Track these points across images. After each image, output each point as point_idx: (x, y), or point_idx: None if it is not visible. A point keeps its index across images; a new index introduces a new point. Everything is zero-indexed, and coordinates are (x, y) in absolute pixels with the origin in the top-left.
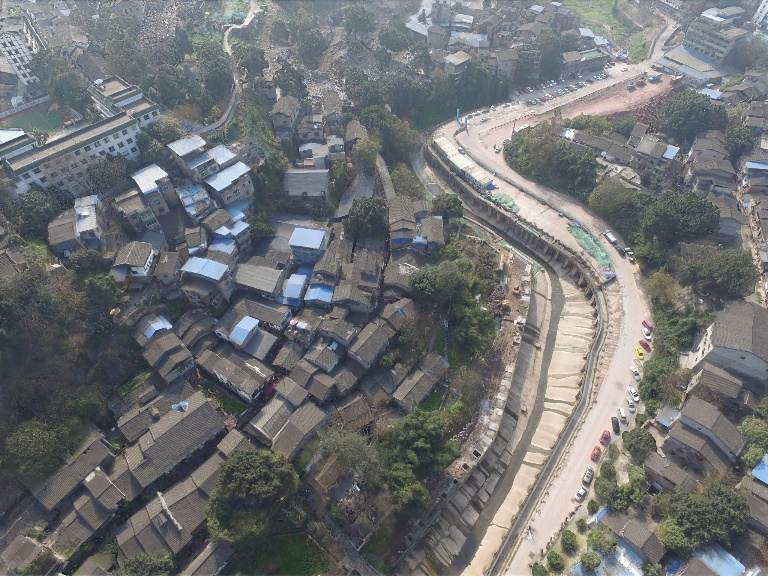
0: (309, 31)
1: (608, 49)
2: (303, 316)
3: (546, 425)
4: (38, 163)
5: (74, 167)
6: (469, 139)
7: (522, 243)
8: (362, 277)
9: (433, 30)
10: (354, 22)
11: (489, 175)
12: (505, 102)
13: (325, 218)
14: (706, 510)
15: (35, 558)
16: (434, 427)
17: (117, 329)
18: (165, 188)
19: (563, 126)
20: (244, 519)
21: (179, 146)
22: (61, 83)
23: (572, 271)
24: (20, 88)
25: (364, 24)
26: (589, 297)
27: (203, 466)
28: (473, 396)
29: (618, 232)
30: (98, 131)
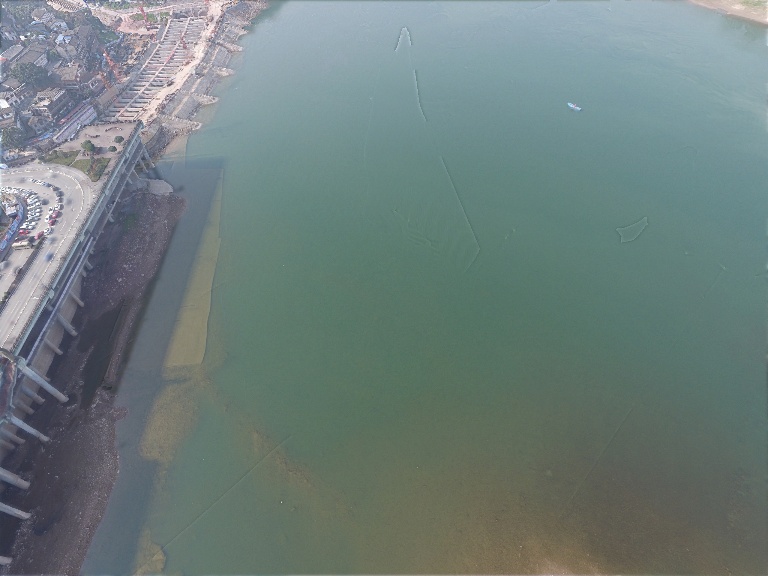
0: None
1: None
2: None
3: (55, 7)
4: None
5: None
6: None
7: None
8: None
9: None
10: None
11: None
12: None
13: None
14: None
15: None
16: None
17: None
18: None
19: None
20: (21, 1)
21: None
22: None
23: None
24: None
25: None
26: None
27: None
28: None
29: None
30: None
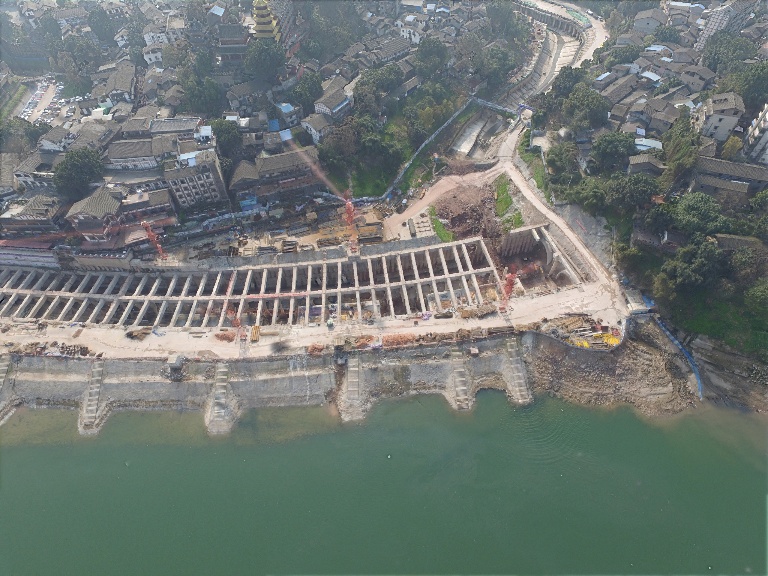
0: None
1: None
2: None
3: None
4: None
5: None
6: None
7: None
8: (463, 5)
9: None
10: None
11: None
12: None
13: None
14: (622, 49)
15: (355, 59)
16: (505, 50)
17: (355, 12)
18: None
19: None
20: None
21: None
22: None
23: (569, 30)
24: None
25: None
26: (578, 39)
27: (404, 58)
28: (519, 58)
29: (594, 11)
30: None
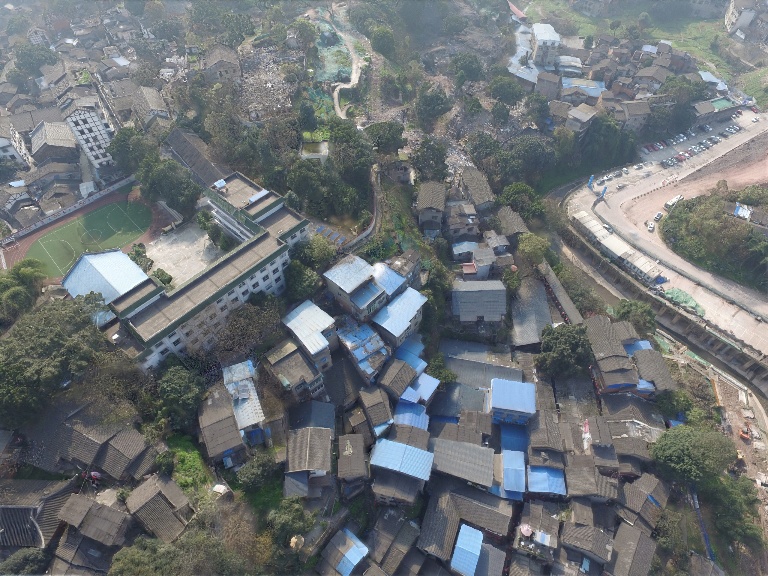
0: (416, 84)
1: (729, 94)
2: (533, 517)
3: None
4: (175, 326)
5: (212, 317)
6: (611, 213)
7: (710, 352)
8: (595, 451)
9: (545, 77)
10: (465, 72)
11: (652, 262)
12: (635, 162)
13: (502, 346)
14: None
15: None
16: None
17: (303, 570)
18: (327, 335)
19: (727, 199)
20: None
21: (342, 277)
22: (159, 178)
23: None
24: (84, 167)
25: (476, 74)
26: None
27: None
28: None
29: None
30: (240, 264)
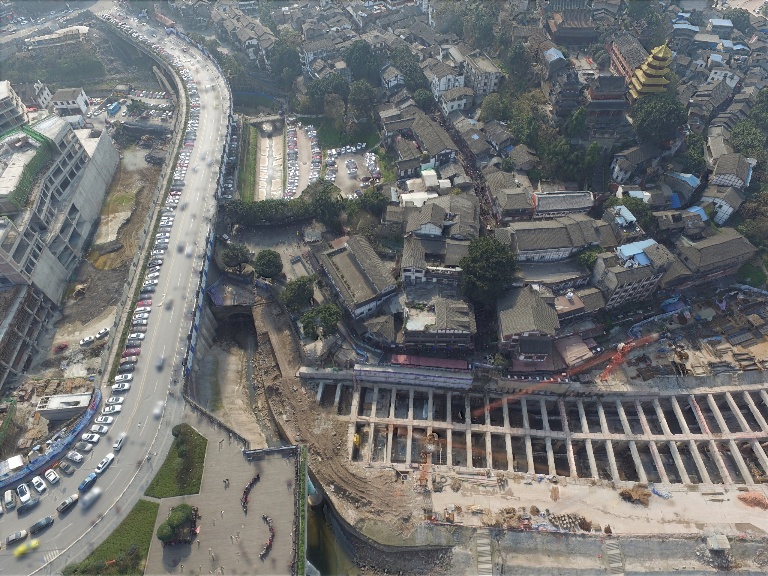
0: None
1: None
2: None
3: None
4: None
5: None
6: (733, 7)
7: None
8: None
9: None
10: None
11: None
12: None
13: None
14: None
15: (707, 112)
16: None
17: None
18: None
19: None
20: None
21: None
22: None
23: None
24: None
25: None
26: None
27: None
28: None
29: None
30: None
